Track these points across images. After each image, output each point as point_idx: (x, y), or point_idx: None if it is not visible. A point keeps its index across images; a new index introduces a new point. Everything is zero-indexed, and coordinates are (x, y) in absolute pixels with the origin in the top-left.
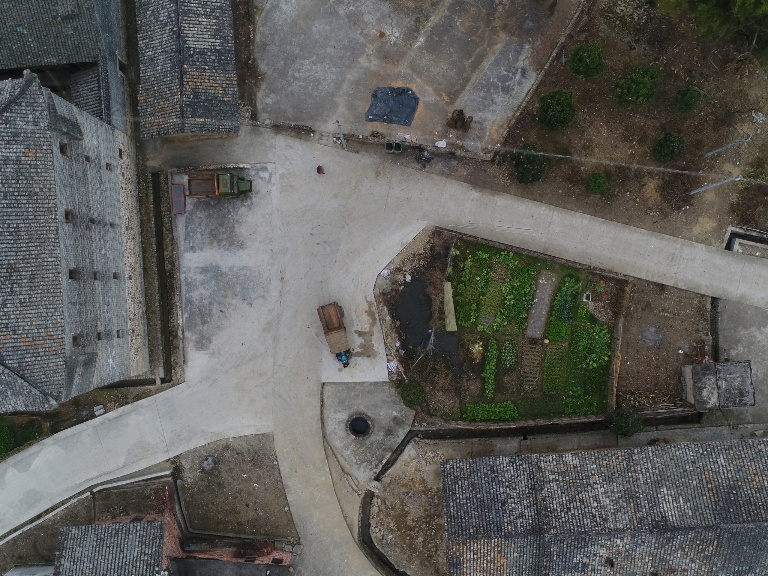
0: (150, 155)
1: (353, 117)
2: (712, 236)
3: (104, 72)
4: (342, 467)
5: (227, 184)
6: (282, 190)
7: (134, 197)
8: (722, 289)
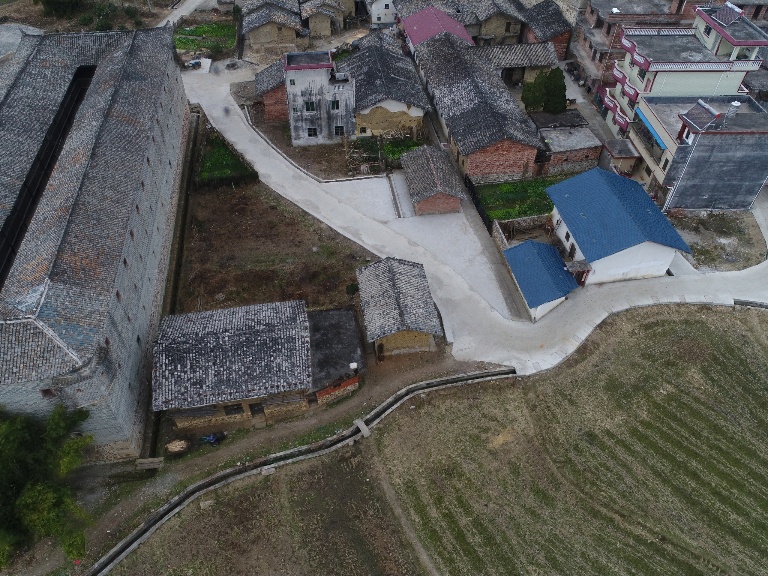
0: None
1: None
2: None
3: None
4: None
5: None
6: None
7: None
8: None
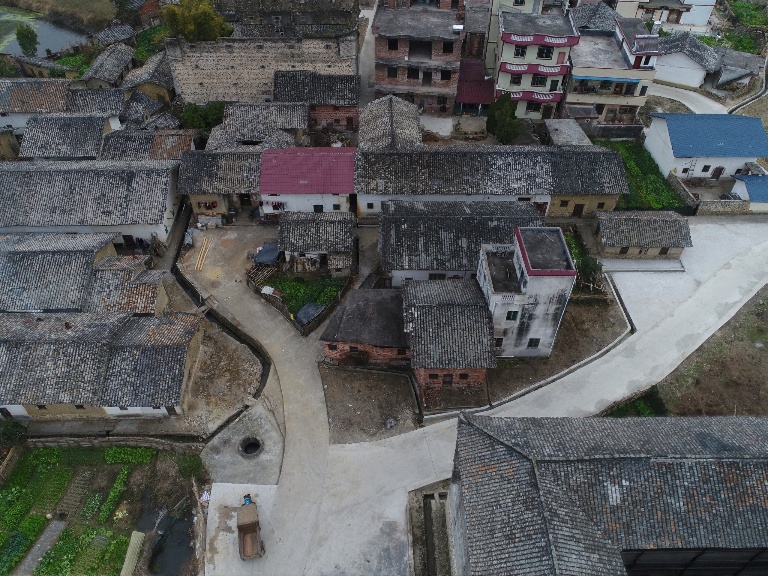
0: None
1: None
2: None
3: None
4: (274, 416)
5: None
6: None
7: None
8: None
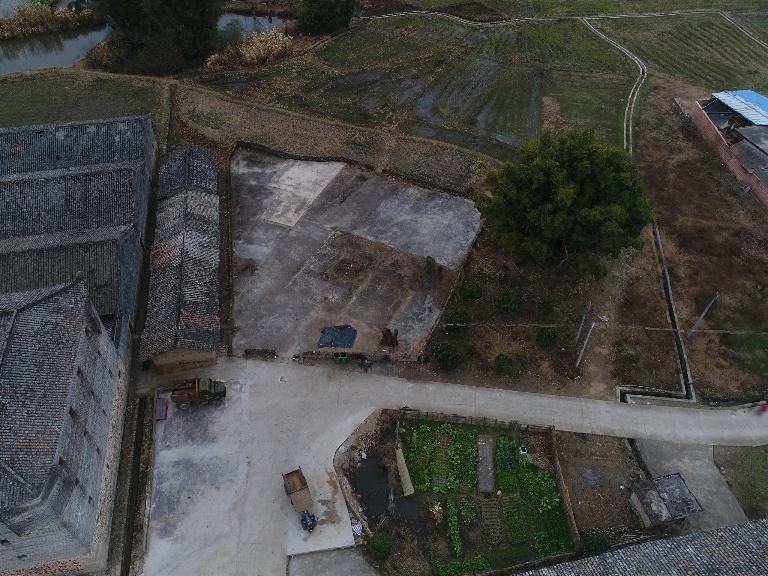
0: (141, 386)
1: (308, 346)
2: (606, 394)
3: (120, 318)
4: None
5: (206, 384)
6: (251, 396)
7: (122, 413)
8: (633, 431)
